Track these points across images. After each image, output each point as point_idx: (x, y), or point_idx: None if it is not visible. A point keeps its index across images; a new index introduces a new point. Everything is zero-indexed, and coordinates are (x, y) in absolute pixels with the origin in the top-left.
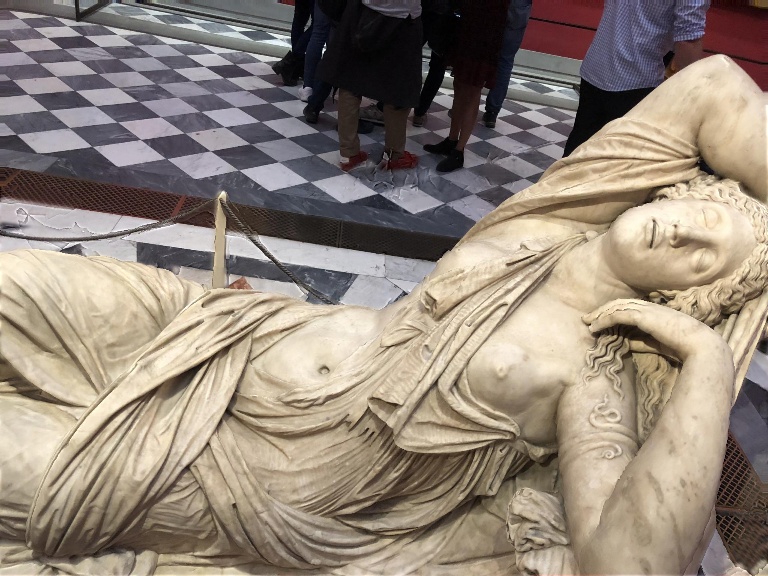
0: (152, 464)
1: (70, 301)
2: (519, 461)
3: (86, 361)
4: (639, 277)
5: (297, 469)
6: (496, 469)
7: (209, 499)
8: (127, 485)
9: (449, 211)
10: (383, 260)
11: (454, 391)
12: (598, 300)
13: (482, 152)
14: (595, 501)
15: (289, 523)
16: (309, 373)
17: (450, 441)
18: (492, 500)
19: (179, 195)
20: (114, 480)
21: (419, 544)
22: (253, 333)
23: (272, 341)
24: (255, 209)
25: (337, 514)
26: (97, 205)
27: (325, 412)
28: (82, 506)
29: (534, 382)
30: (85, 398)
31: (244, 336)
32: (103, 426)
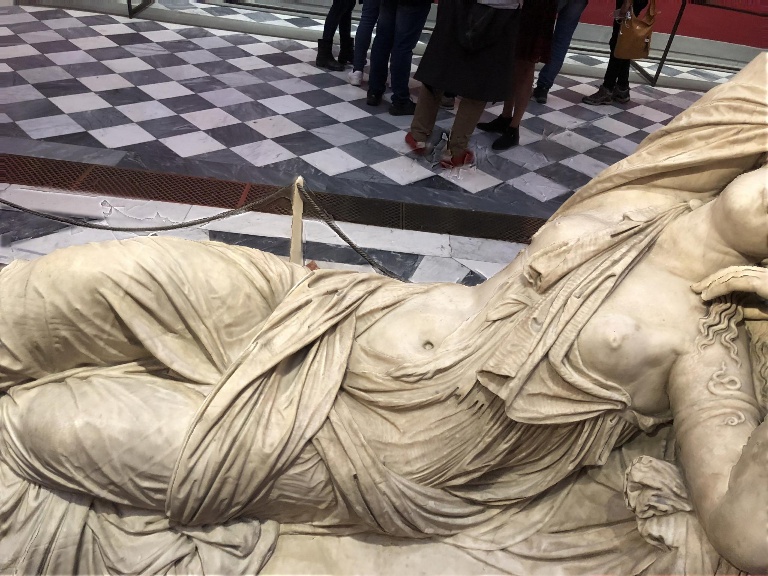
0: (279, 437)
1: (191, 284)
2: (627, 431)
3: (208, 341)
4: (754, 243)
5: (409, 441)
6: (606, 439)
7: (331, 470)
8: (258, 457)
9: (509, 189)
10: (448, 240)
11: (565, 362)
12: (707, 269)
13: (537, 128)
14: (721, 467)
15: (405, 493)
16: (415, 349)
17: (562, 412)
18: (599, 470)
19: (244, 183)
20: (246, 452)
21: (526, 514)
22: (356, 311)
23: (374, 319)
24: (318, 194)
25: (446, 485)
26: (168, 196)
27: (434, 386)
28: (218, 477)
29: (647, 352)
30: (209, 376)
31: (349, 314)
32: (233, 401)
